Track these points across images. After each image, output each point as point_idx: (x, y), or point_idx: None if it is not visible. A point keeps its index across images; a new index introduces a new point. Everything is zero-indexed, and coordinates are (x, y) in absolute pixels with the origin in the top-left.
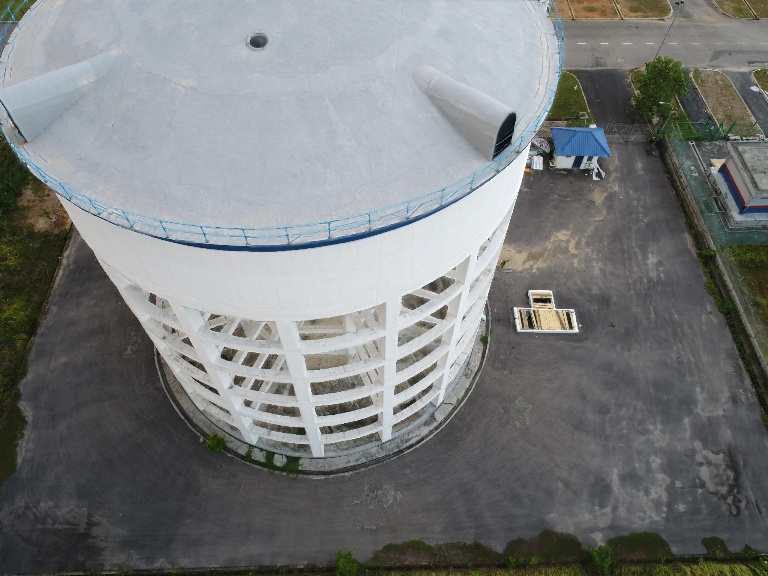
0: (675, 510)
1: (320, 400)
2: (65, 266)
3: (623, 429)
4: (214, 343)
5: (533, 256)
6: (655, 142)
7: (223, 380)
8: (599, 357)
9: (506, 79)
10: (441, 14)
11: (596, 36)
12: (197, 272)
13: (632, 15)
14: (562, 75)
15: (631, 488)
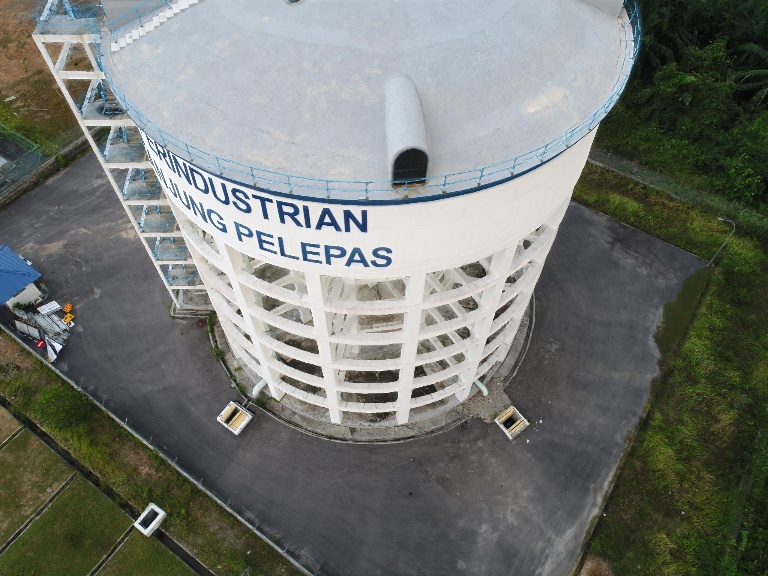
0: None
1: None
2: (600, 492)
3: None
4: None
5: None
6: None
7: None
8: None
9: None
10: None
11: None
12: None
13: None
14: None
15: None
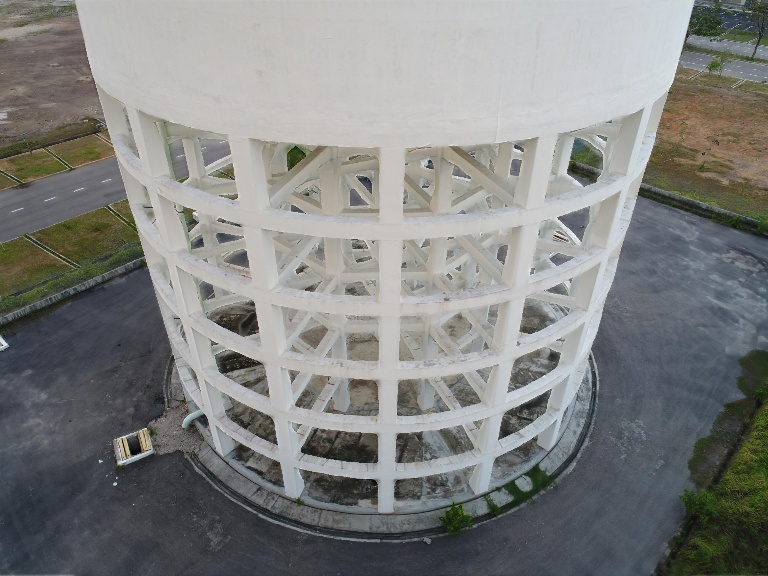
0: (763, 293)
1: (598, 297)
2: None
3: (676, 274)
4: (561, 213)
5: None
6: None
7: None
8: None
9: None
10: None
11: None
12: (616, 23)
13: None
14: None
15: (730, 300)
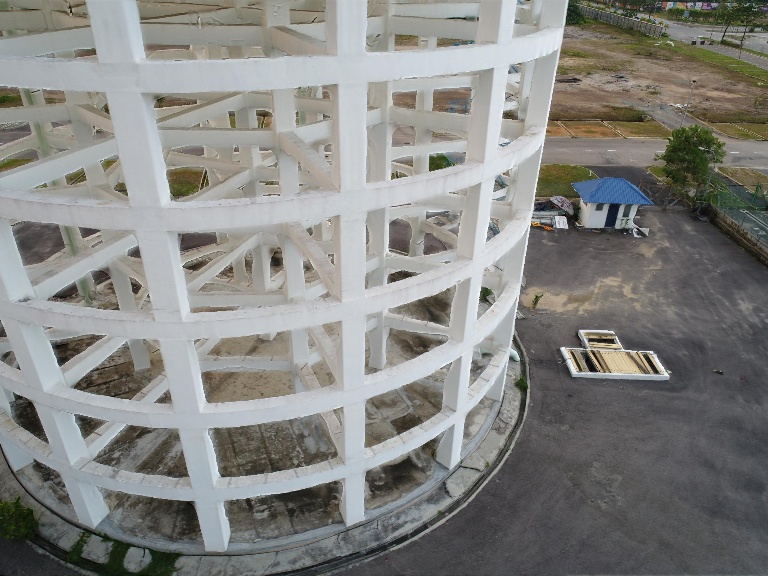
0: None
1: (204, 318)
2: None
3: None
4: None
5: (576, 298)
6: (700, 208)
7: (6, 272)
8: (714, 411)
9: None
10: None
11: (601, 146)
12: None
13: (635, 135)
14: (572, 167)
15: None
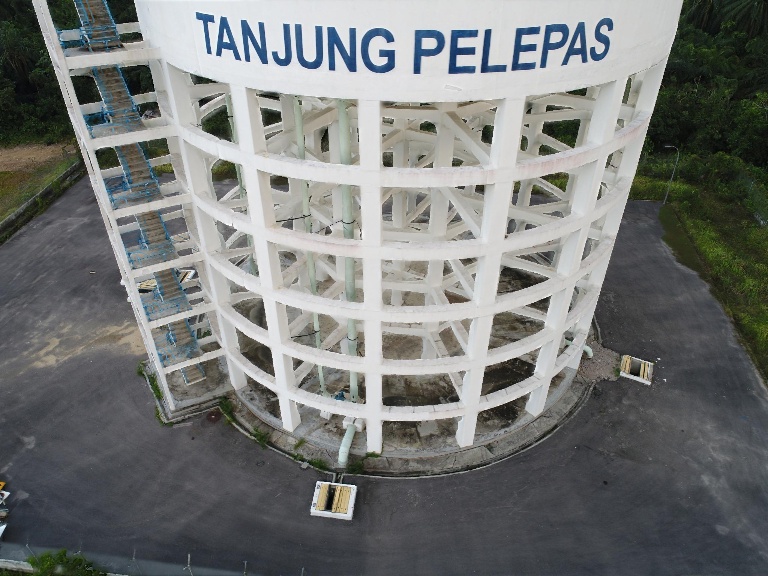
0: None
1: None
2: (765, 394)
3: None
4: None
5: (113, 338)
6: None
7: None
8: None
9: None
10: None
11: None
12: None
13: None
14: None
15: None
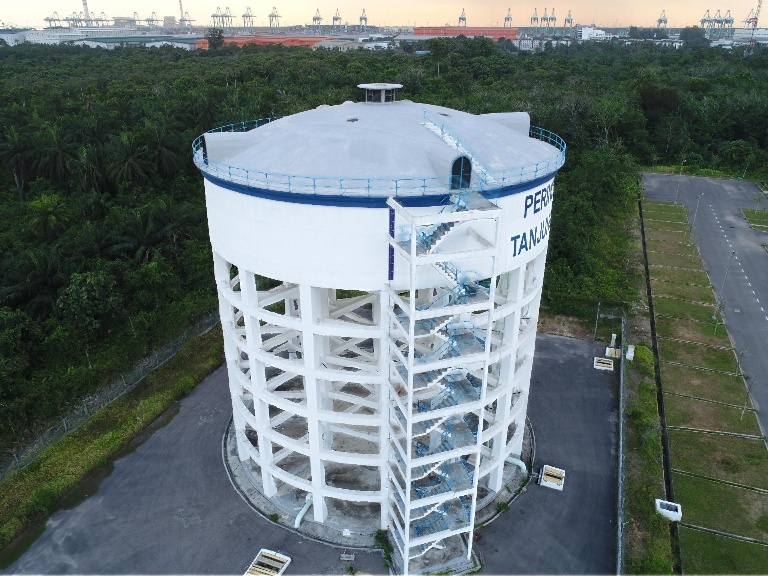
0: None
1: None
2: None
3: None
4: None
5: None
6: None
7: None
8: None
9: (252, 162)
10: (312, 135)
11: None
12: None
13: None
14: None
15: (52, 570)
